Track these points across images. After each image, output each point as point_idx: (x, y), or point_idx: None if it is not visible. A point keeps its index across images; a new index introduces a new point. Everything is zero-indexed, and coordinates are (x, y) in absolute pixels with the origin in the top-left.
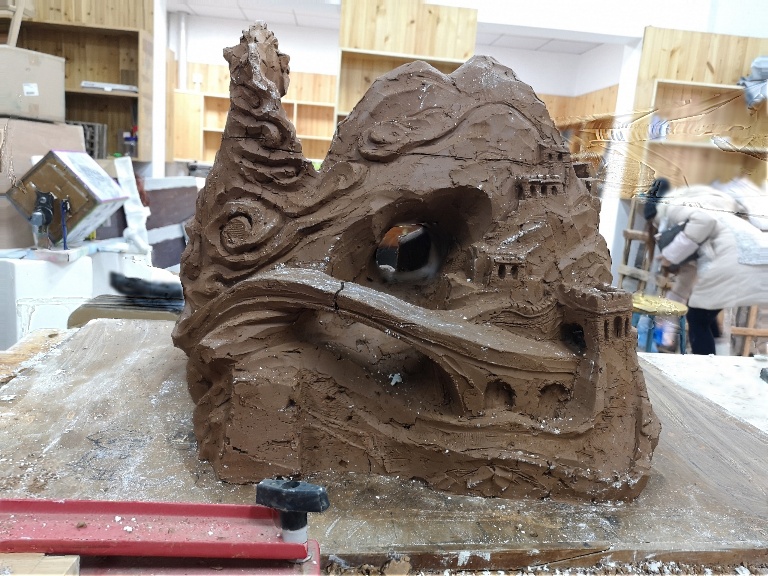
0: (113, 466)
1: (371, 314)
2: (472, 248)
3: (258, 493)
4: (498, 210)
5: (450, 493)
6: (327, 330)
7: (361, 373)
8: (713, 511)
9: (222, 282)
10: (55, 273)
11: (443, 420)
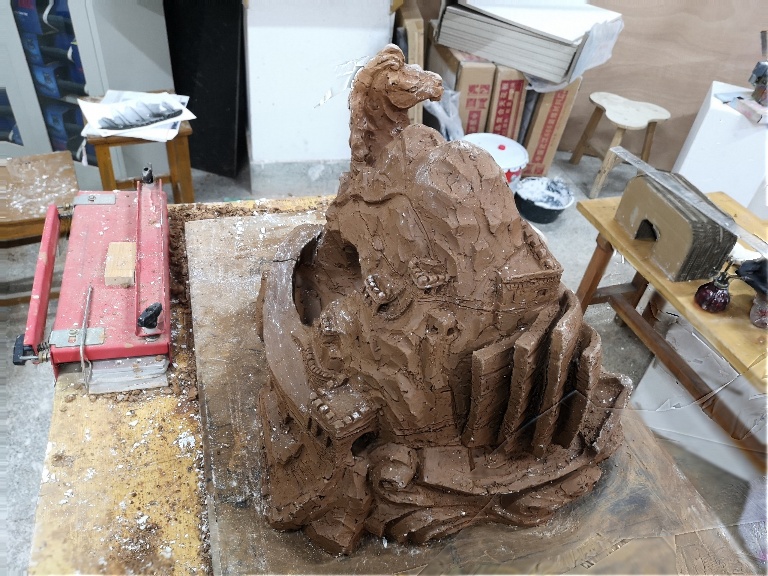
0: None
1: None
2: None
3: None
4: None
5: None
6: (319, 283)
7: (302, 319)
8: None
9: None
10: (744, 129)
11: None
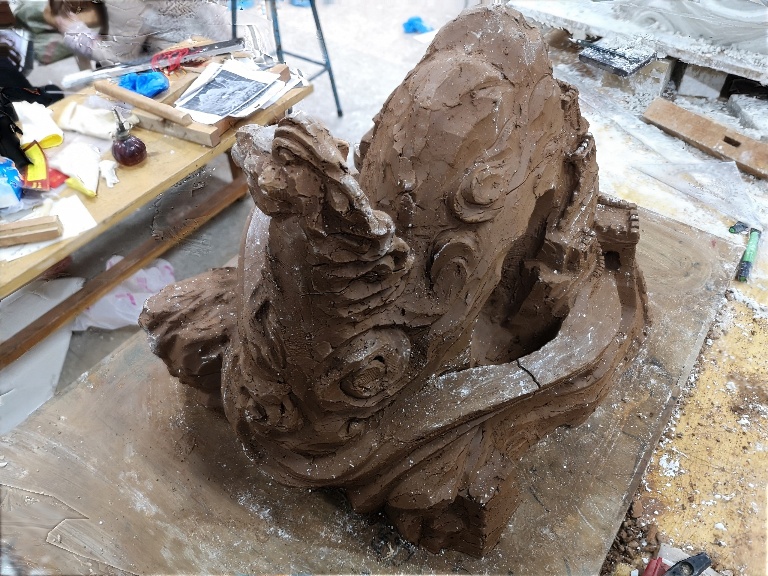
0: None
1: (562, 379)
2: (552, 244)
3: None
4: (557, 193)
5: (585, 421)
6: None
7: None
8: (672, 308)
9: (353, 420)
10: None
11: (579, 388)
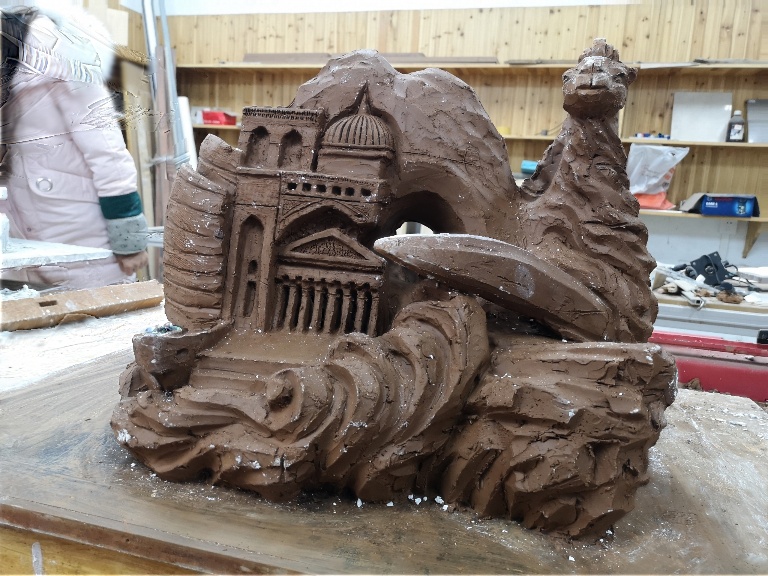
0: None
1: None
2: None
3: None
4: None
5: None
6: None
7: None
8: None
9: None
10: None
11: None
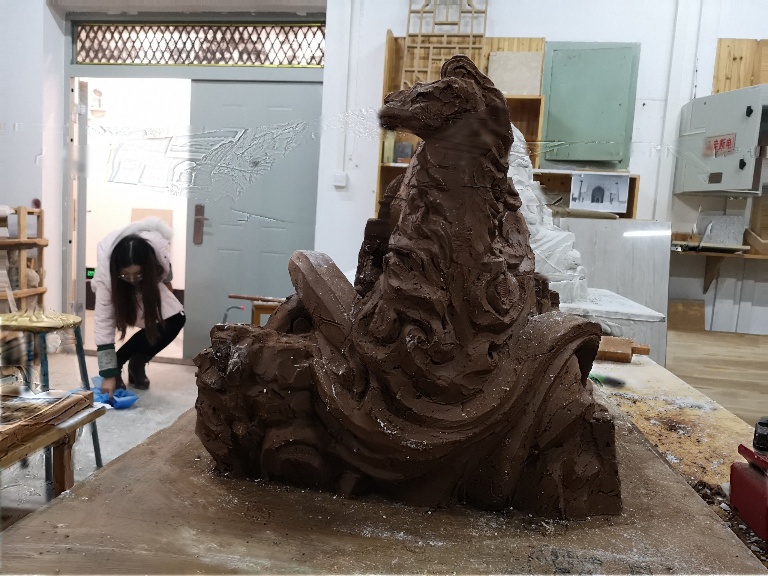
0: (621, 567)
1: None
2: None
3: (767, 440)
4: None
5: None
6: None
7: None
8: None
9: None
10: None
11: None
